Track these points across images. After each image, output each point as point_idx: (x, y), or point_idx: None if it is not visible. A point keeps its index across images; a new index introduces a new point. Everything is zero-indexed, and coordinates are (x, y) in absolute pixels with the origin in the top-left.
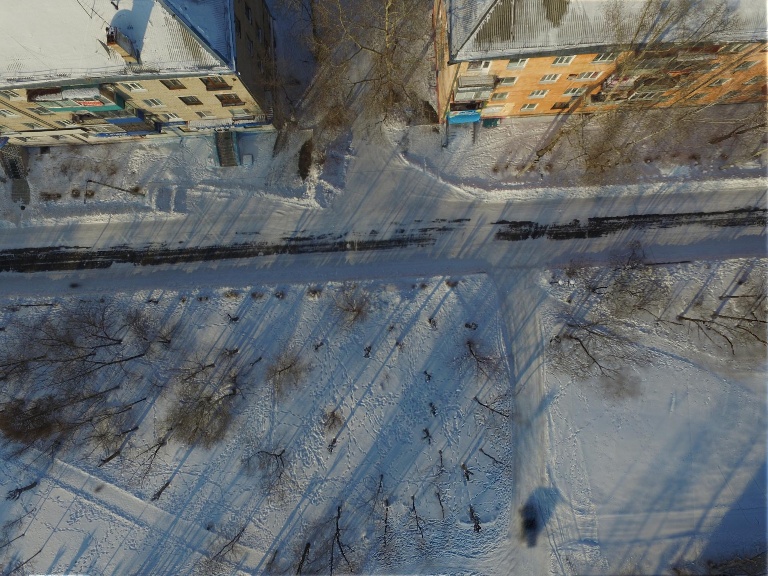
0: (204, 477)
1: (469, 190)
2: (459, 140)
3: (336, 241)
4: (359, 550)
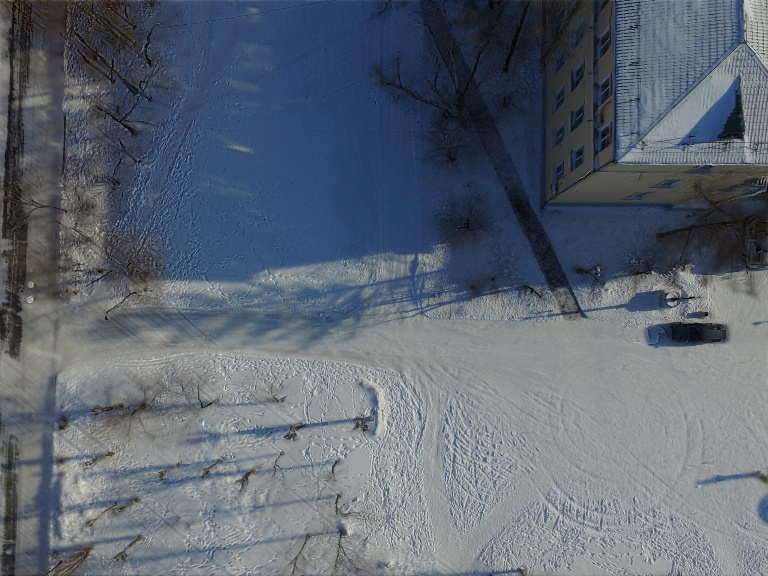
0: None
1: None
2: None
3: None
4: (405, 575)
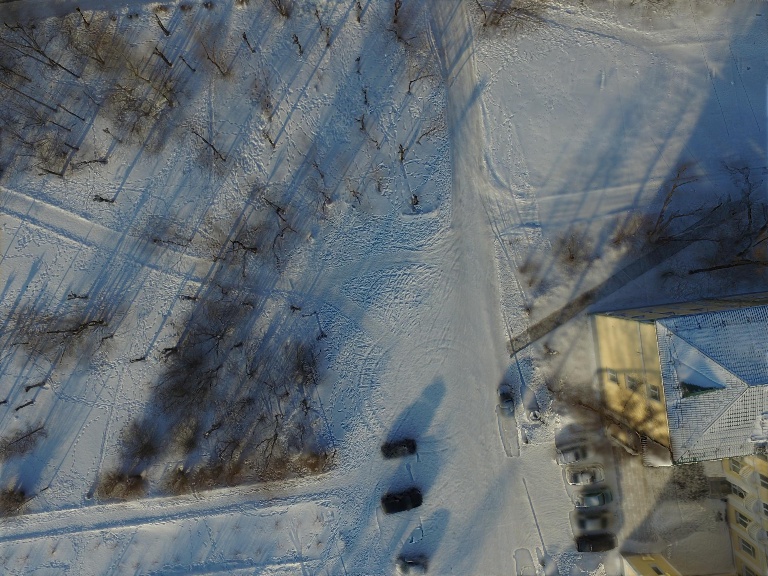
0: (148, 193)
1: None
2: None
3: None
4: (306, 251)
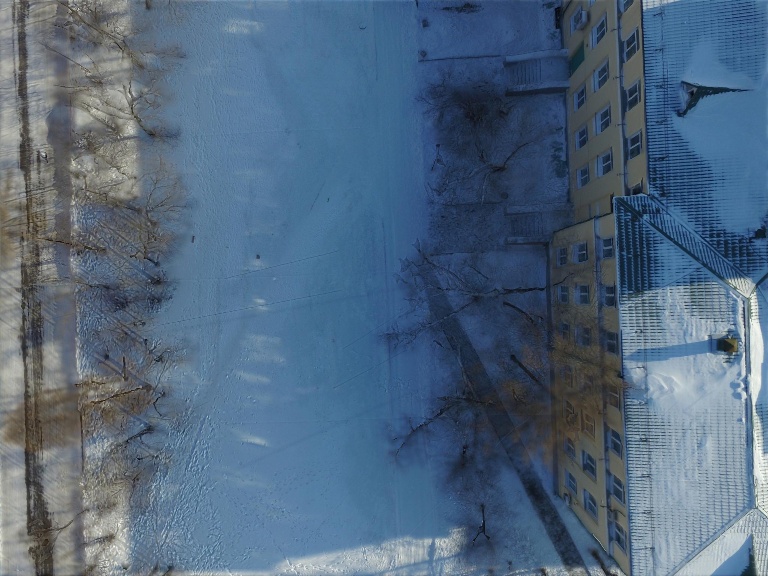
0: None
1: None
2: None
3: None
4: None
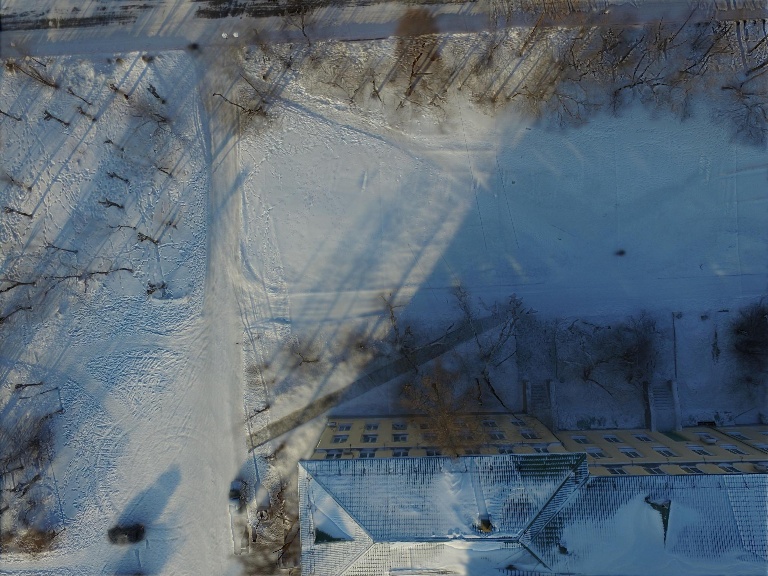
0: None
1: None
2: None
3: (38, 18)
4: (53, 326)
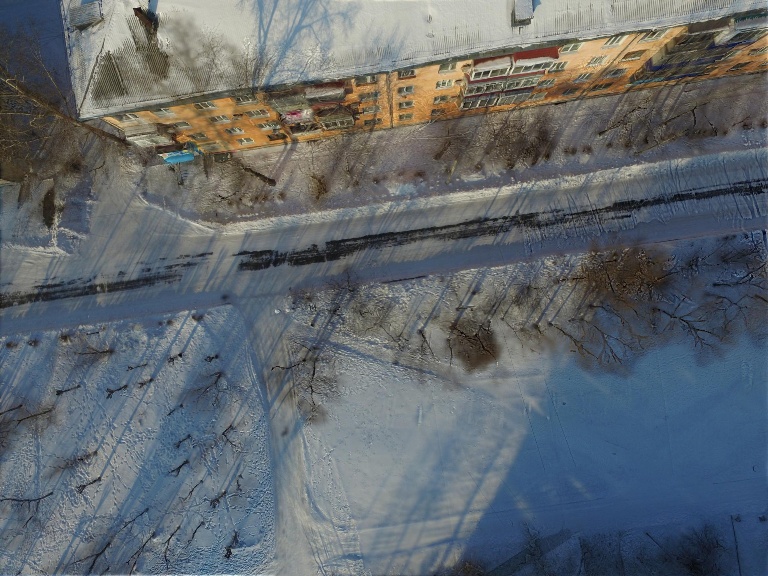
0: None
1: (207, 225)
2: (193, 177)
3: (86, 285)
4: None
